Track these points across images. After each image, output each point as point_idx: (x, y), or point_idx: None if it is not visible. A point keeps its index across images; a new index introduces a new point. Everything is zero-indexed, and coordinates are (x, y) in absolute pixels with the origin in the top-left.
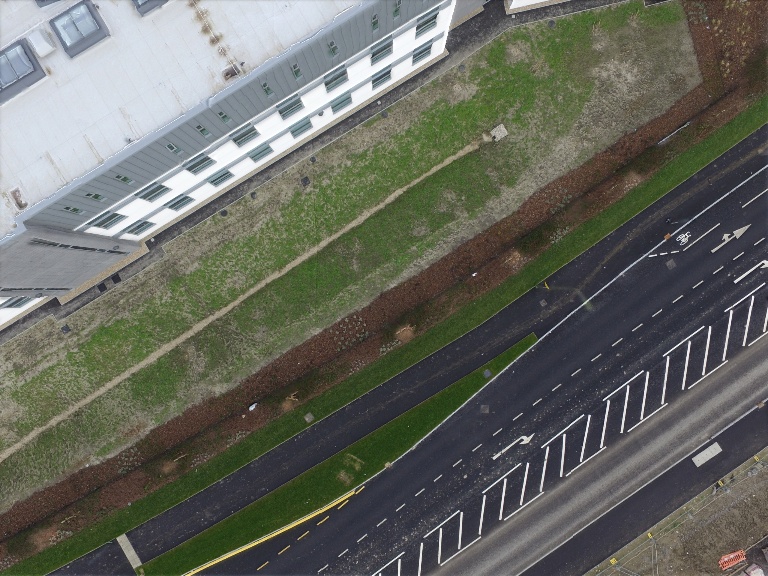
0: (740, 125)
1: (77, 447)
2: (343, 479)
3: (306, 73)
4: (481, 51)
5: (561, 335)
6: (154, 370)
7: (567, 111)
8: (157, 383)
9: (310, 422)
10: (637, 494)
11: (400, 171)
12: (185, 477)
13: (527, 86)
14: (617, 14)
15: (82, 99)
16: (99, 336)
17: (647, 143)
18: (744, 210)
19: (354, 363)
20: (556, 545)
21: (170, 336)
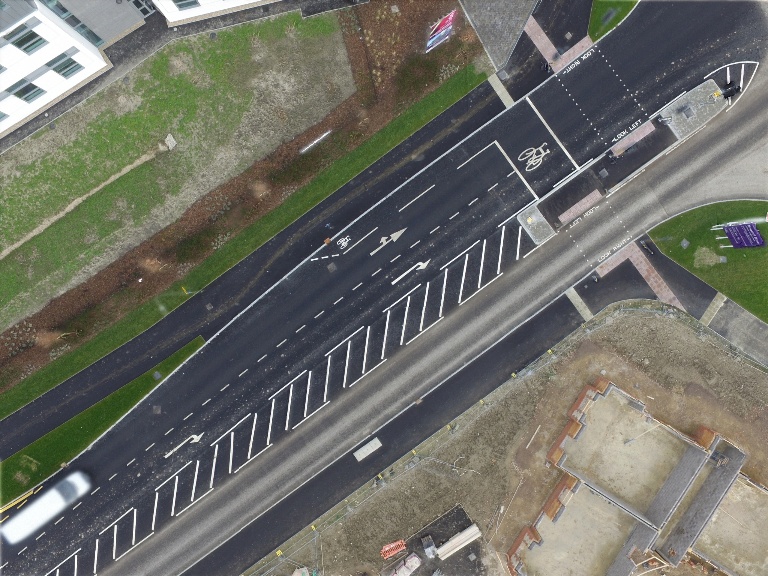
0: (392, 132)
1: None
2: (20, 480)
3: None
4: (145, 63)
5: (228, 337)
6: None
7: (227, 121)
8: None
9: None
10: (301, 488)
11: (75, 181)
12: None
13: (190, 97)
14: (275, 26)
15: None
16: None
17: (304, 151)
18: (400, 214)
19: (26, 368)
20: (225, 539)
21: None
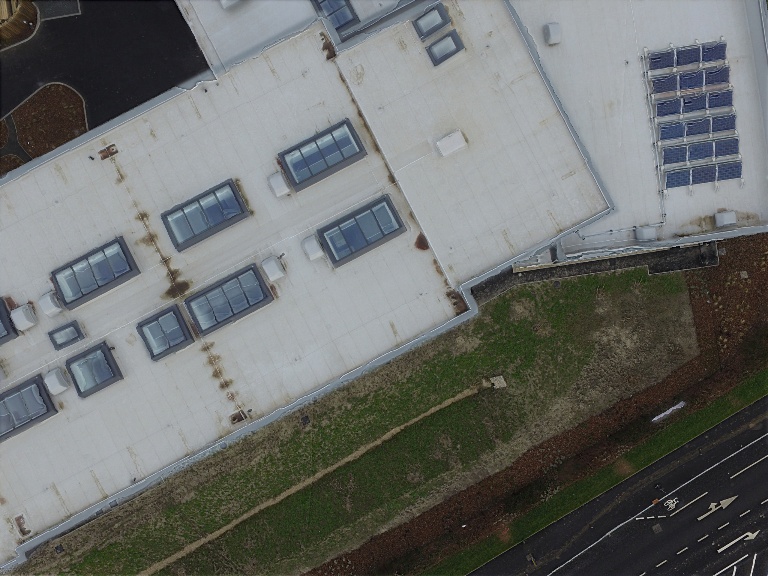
0: (733, 400)
1: None
2: None
3: None
4: (486, 306)
5: None
6: None
7: (566, 372)
8: None
9: None
10: None
11: (399, 412)
12: None
13: (528, 344)
14: (621, 280)
15: (91, 436)
16: (92, 558)
17: (642, 410)
18: (732, 481)
19: None
20: None
21: (162, 556)
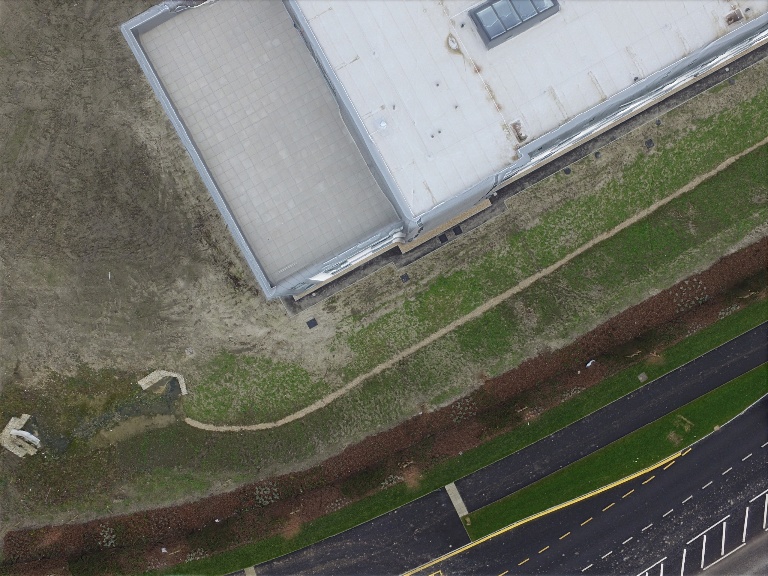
0: None
1: (408, 395)
2: (672, 440)
3: (767, 26)
4: None
5: None
6: (481, 323)
7: None
8: (486, 336)
9: (644, 382)
10: None
11: (737, 139)
12: (517, 429)
13: None
14: None
15: (590, 36)
16: (438, 286)
17: None
18: None
19: (691, 325)
20: None
21: (498, 291)
